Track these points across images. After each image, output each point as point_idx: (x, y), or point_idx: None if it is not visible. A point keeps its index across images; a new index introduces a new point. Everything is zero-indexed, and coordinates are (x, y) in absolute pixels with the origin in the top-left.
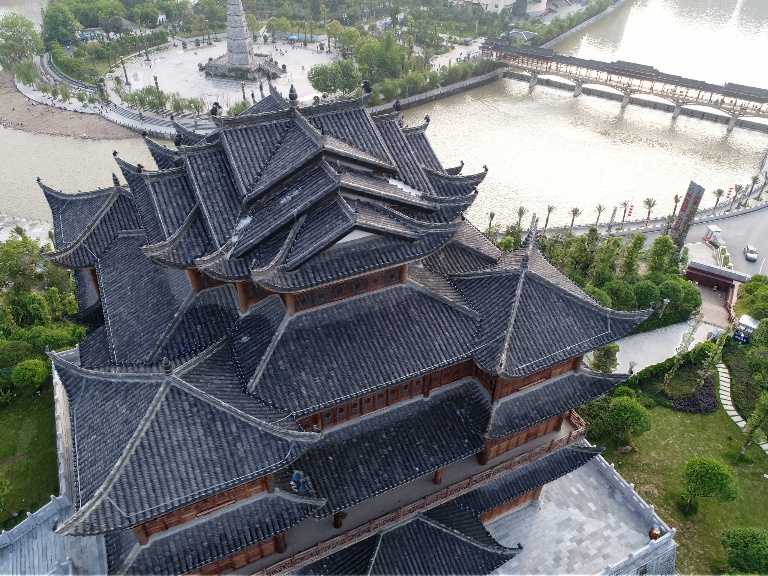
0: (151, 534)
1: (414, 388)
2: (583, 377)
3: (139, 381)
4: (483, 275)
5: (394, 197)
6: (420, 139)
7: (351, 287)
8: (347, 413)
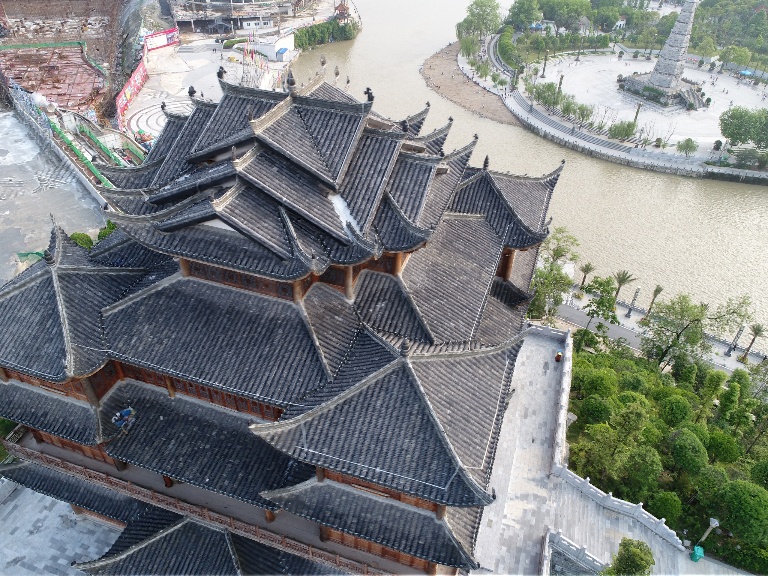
0: (13, 378)
1: (265, 410)
2: (441, 529)
3: None
4: (381, 342)
5: (298, 209)
6: (425, 172)
7: (242, 279)
8: (197, 391)
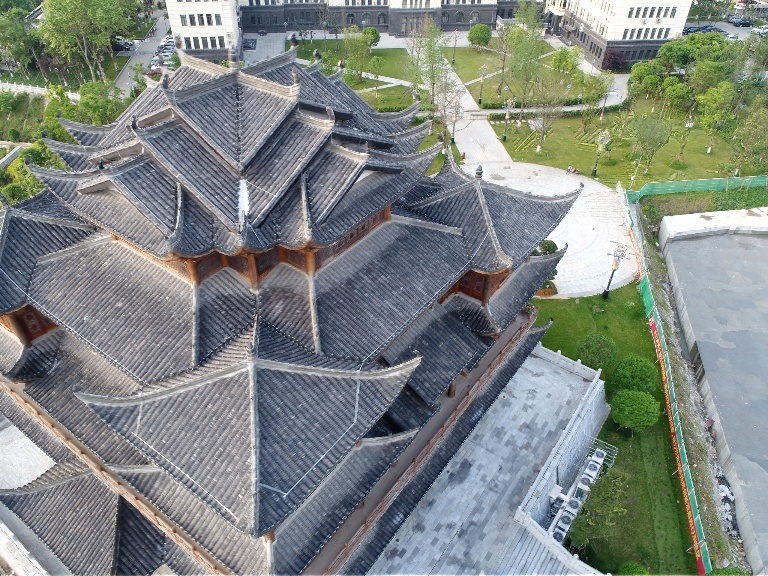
0: None
1: None
2: None
3: None
4: None
5: None
6: None
7: None
8: None
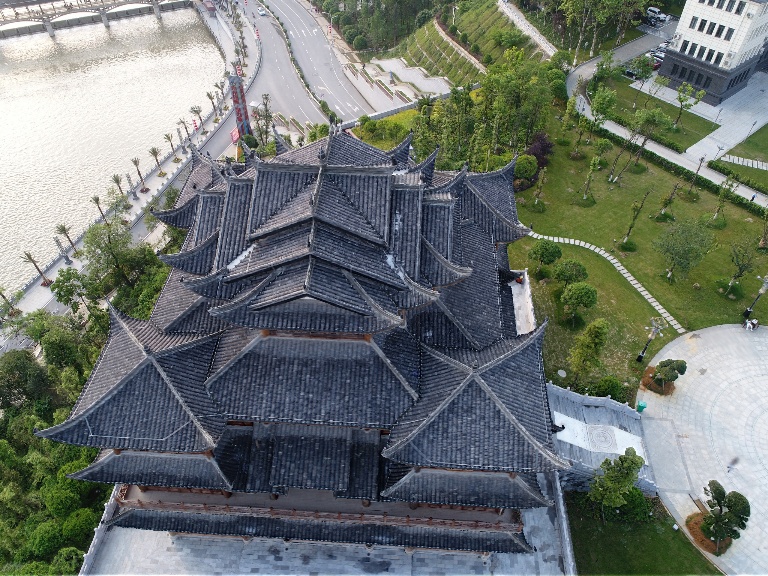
0: None
1: None
2: None
3: (453, 399)
4: None
5: None
6: None
7: None
8: None
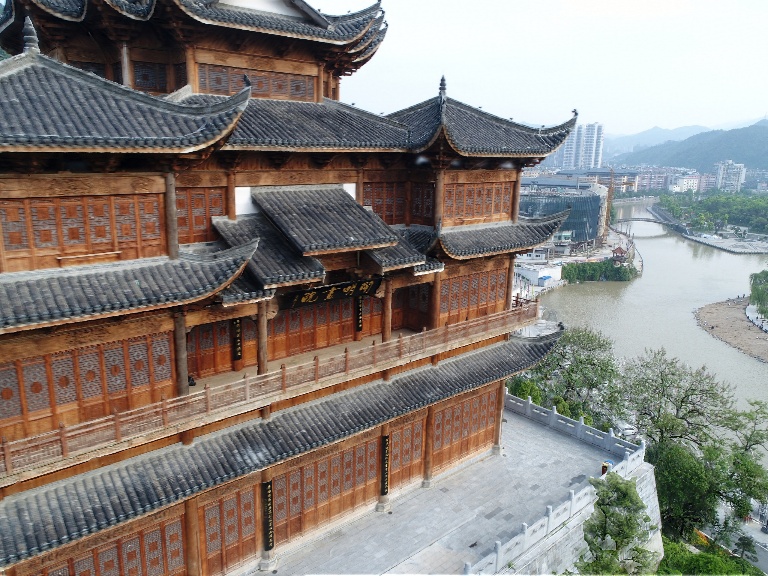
0: None
1: None
2: None
3: None
4: None
5: None
6: None
7: None
8: None
